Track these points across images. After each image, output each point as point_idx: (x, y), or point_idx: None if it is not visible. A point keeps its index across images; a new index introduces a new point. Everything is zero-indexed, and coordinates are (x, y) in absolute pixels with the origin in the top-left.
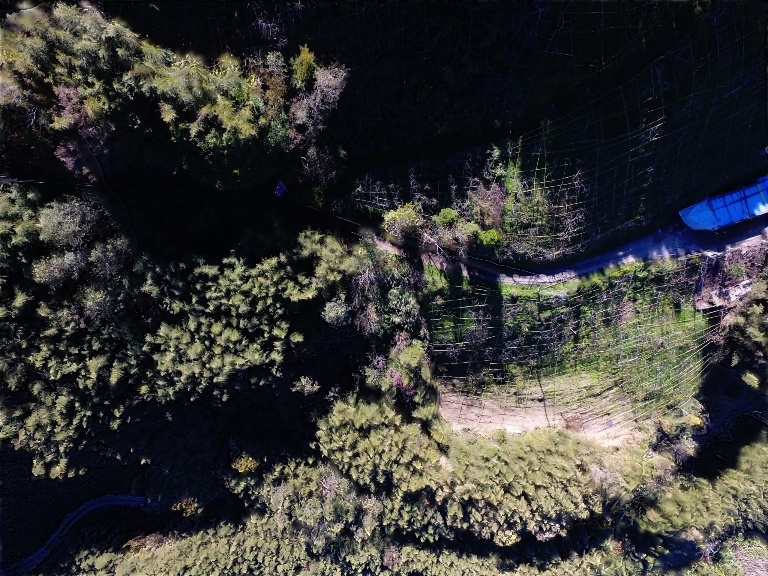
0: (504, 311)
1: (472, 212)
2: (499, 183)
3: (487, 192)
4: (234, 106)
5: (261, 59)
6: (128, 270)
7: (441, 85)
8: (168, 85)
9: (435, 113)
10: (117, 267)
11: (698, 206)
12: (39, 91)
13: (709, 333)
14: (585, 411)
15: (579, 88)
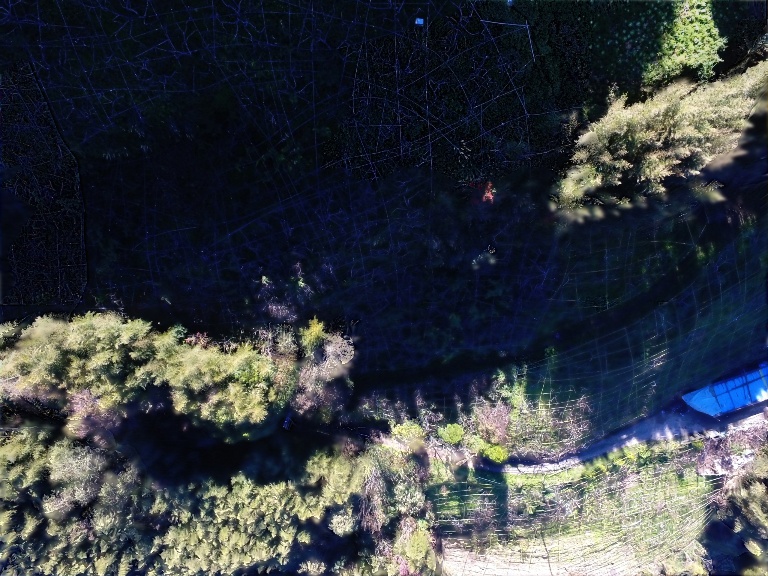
0: (509, 500)
1: (478, 428)
2: (504, 402)
3: (493, 409)
4: (245, 390)
5: (271, 330)
6: (137, 493)
7: (448, 328)
8: (180, 381)
9: (441, 349)
10: (126, 494)
11: (701, 392)
12: (53, 392)
13: (712, 496)
14: (589, 564)
15: (583, 322)
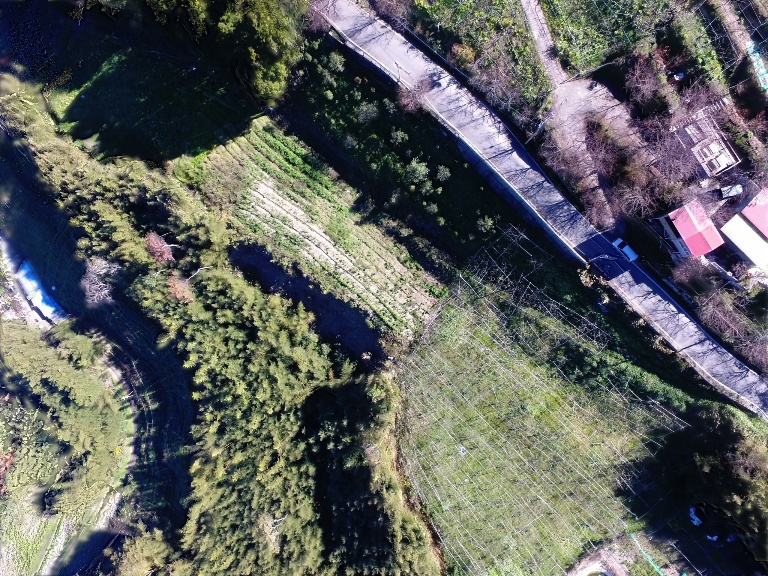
0: None
1: None
2: None
3: None
4: None
5: None
6: None
7: None
8: None
9: None
10: None
11: (26, 267)
12: None
13: None
14: None
15: None
